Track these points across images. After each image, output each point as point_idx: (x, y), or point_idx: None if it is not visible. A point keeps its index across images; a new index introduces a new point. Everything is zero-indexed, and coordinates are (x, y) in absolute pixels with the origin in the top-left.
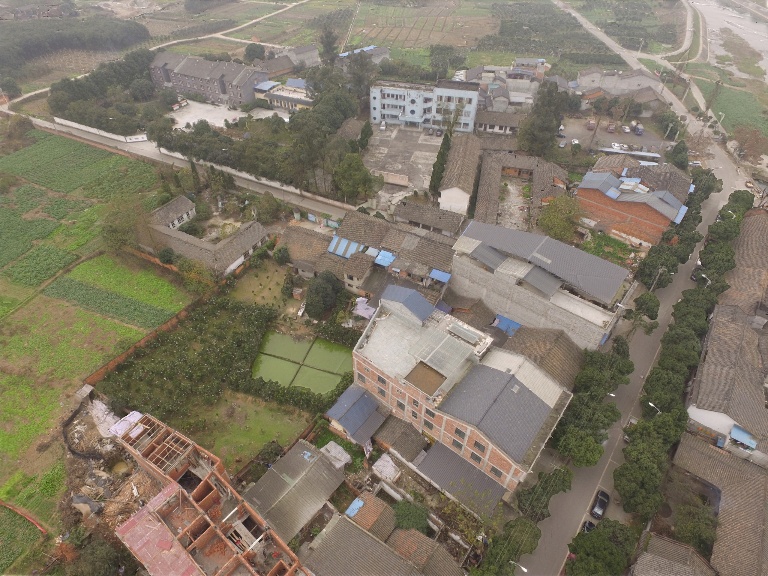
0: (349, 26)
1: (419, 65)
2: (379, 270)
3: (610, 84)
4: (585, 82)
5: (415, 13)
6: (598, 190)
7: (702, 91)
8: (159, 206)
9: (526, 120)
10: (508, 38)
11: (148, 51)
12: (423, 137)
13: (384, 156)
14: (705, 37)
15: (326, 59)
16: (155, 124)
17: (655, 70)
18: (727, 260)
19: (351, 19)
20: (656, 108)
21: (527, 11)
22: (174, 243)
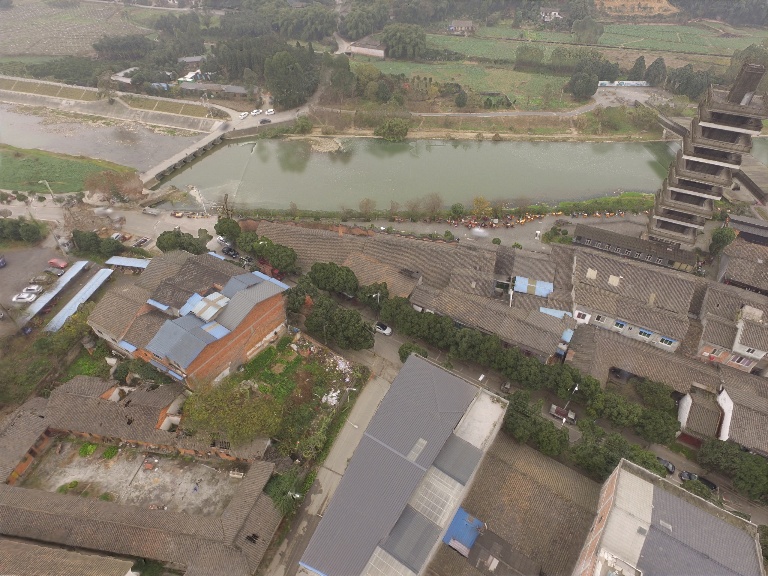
0: None
1: None
2: None
3: None
4: None
5: None
6: (207, 345)
7: None
8: None
9: None
10: None
11: None
12: None
13: None
14: None
15: None
16: None
17: None
18: (346, 271)
19: None
20: None
21: None
22: None
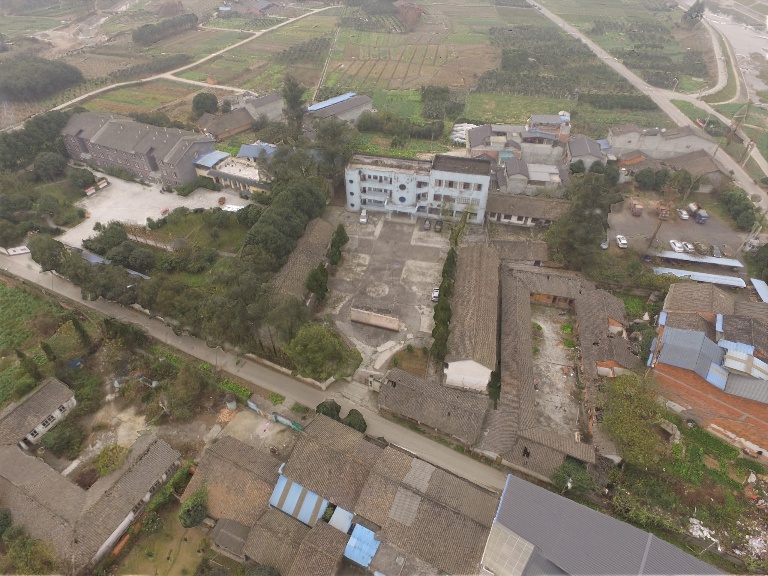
0: (325, 60)
1: (409, 118)
2: (352, 564)
3: (651, 145)
4: (619, 143)
5: (402, 41)
6: (693, 372)
7: (758, 146)
8: (14, 400)
9: (560, 223)
10: (513, 75)
11: (58, 114)
12: (417, 234)
13: (365, 270)
14: (737, 66)
15: (291, 116)
16: (36, 242)
17: (697, 119)
18: None
19: (328, 50)
20: (717, 182)
21: (530, 37)
22: (14, 497)
